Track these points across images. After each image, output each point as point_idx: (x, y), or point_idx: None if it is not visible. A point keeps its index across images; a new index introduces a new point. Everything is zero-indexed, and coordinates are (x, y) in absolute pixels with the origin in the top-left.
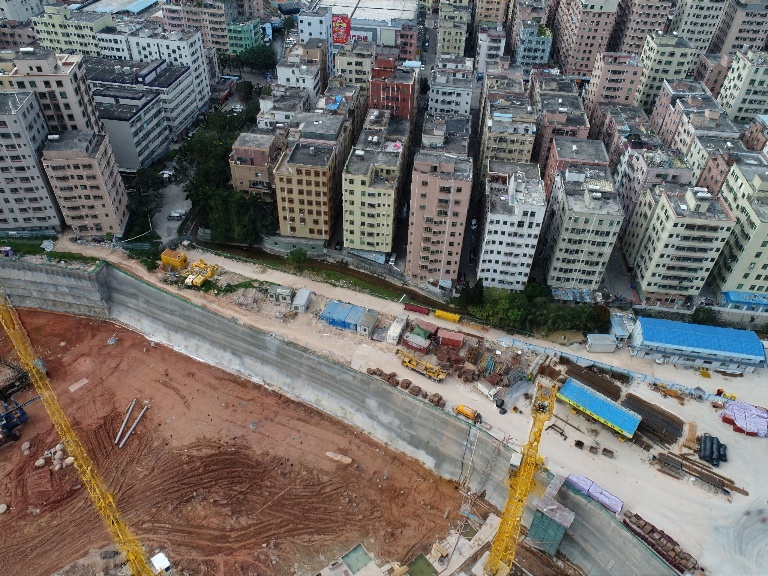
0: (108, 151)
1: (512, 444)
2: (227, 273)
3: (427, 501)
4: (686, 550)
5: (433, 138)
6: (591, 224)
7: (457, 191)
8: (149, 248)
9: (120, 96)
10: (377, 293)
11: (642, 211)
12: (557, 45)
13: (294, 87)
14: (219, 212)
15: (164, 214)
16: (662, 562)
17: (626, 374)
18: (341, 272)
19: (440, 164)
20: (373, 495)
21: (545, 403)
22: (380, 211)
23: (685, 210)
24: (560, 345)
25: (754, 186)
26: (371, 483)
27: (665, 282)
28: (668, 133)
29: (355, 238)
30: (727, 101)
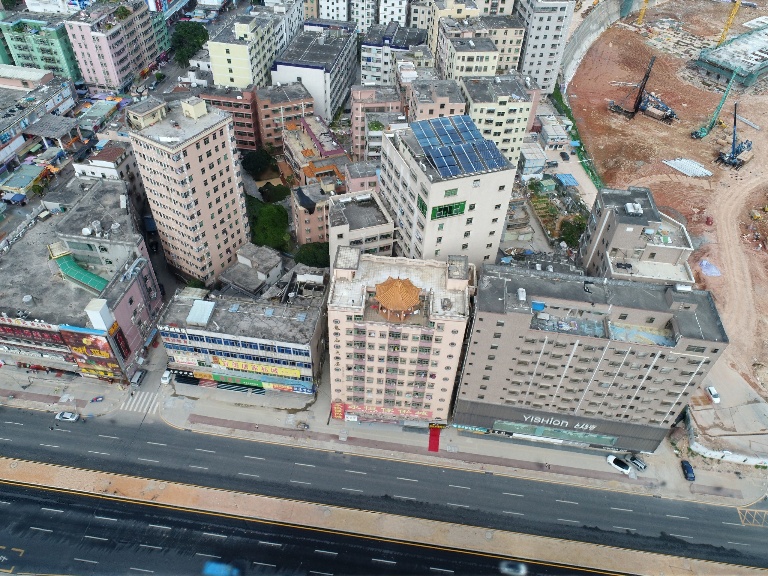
0: None
1: None
2: None
3: None
4: None
5: None
6: None
7: None
8: None
9: None
10: None
11: None
12: None
13: None
14: None
15: None
16: None
17: None
18: None
19: None
20: None
21: None
22: None
23: None
24: None
25: None
26: None
27: None
28: None
29: None
30: None
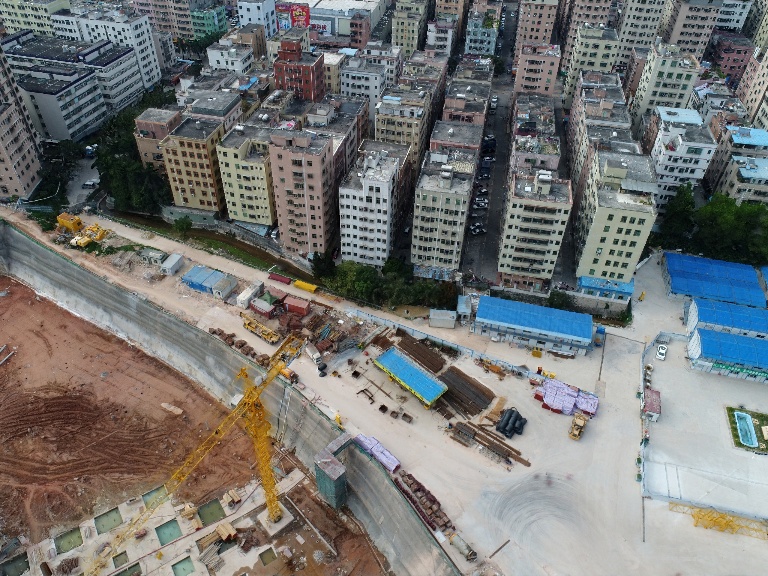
0: (13, 119)
1: (319, 404)
2: (116, 237)
3: (240, 453)
4: (447, 510)
5: (317, 117)
6: (439, 202)
7: (308, 165)
8: (51, 211)
9: (53, 72)
10: (248, 262)
11: (507, 194)
12: (515, 38)
13: (224, 69)
14: (118, 181)
15: (81, 183)
16: (418, 519)
17: (455, 348)
18: (227, 242)
19: (294, 138)
20: (191, 443)
21: (287, 353)
22: (255, 184)
23: (528, 192)
24: (404, 319)
25: (604, 172)
26: (193, 433)
27: (517, 264)
28: (575, 123)
29: (238, 210)
30: (640, 94)
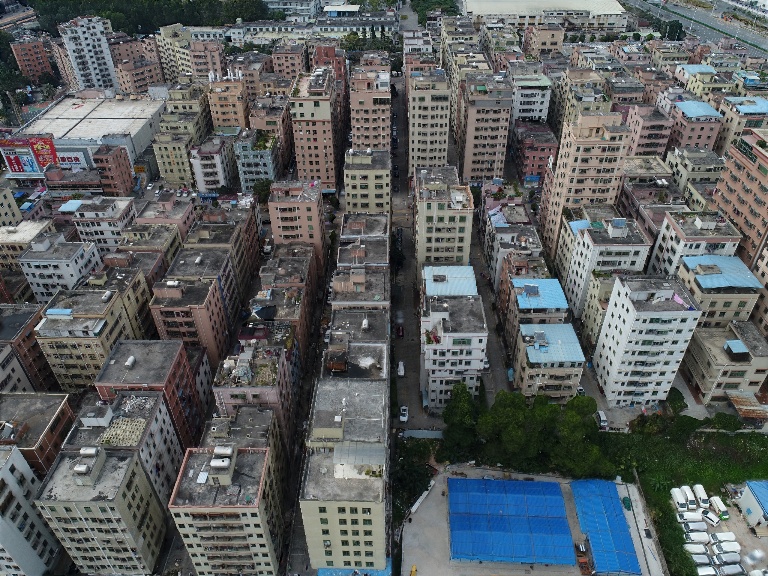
0: None
1: None
2: None
3: None
4: None
5: None
6: (77, 512)
7: None
8: None
9: None
10: None
11: None
12: None
13: None
14: None
15: None
16: None
17: None
18: None
19: None
20: None
21: None
22: None
23: (201, 484)
24: None
25: None
26: None
27: (220, 570)
28: None
29: None
30: (416, 238)
